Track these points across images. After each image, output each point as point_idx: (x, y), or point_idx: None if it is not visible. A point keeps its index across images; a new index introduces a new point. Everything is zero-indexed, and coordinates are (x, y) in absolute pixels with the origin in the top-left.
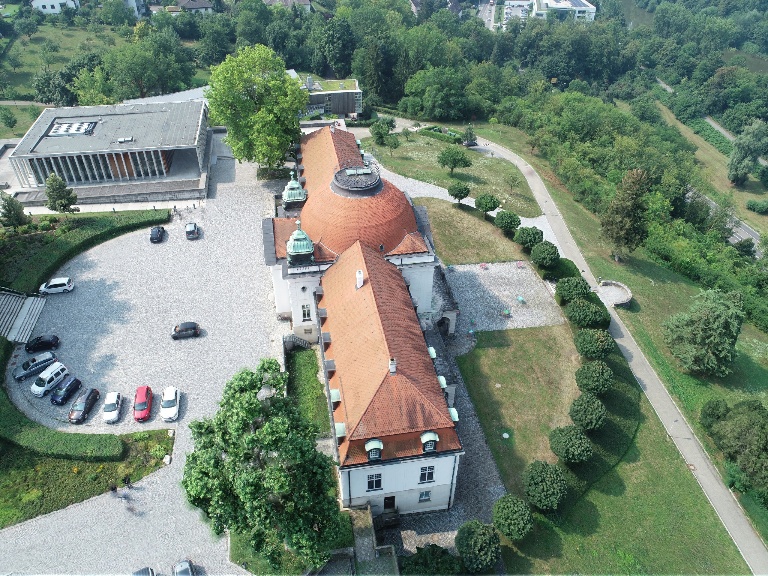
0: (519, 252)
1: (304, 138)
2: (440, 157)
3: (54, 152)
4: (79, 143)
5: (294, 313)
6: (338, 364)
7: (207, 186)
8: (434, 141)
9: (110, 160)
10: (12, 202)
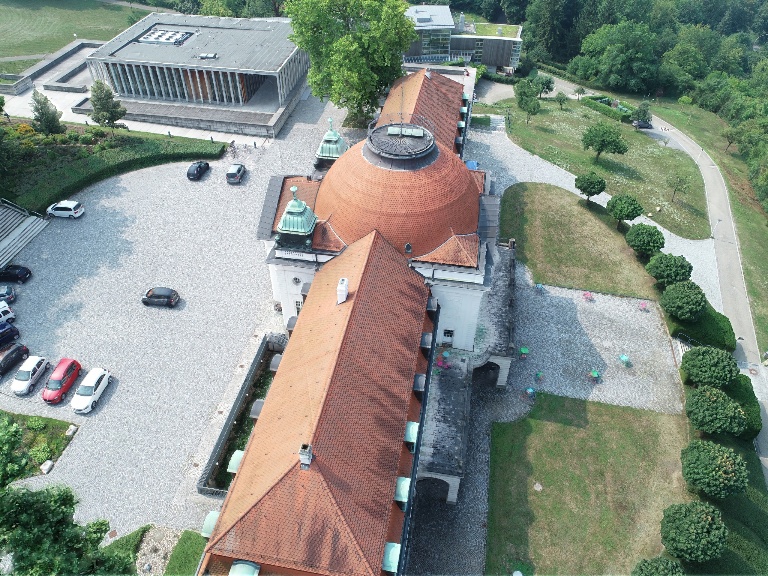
0: (650, 287)
1: (397, 81)
2: (585, 135)
3: (130, 59)
4: (161, 53)
5: (284, 308)
6: (262, 413)
7: (281, 124)
8: (595, 114)
9: (186, 77)
10: (45, 105)
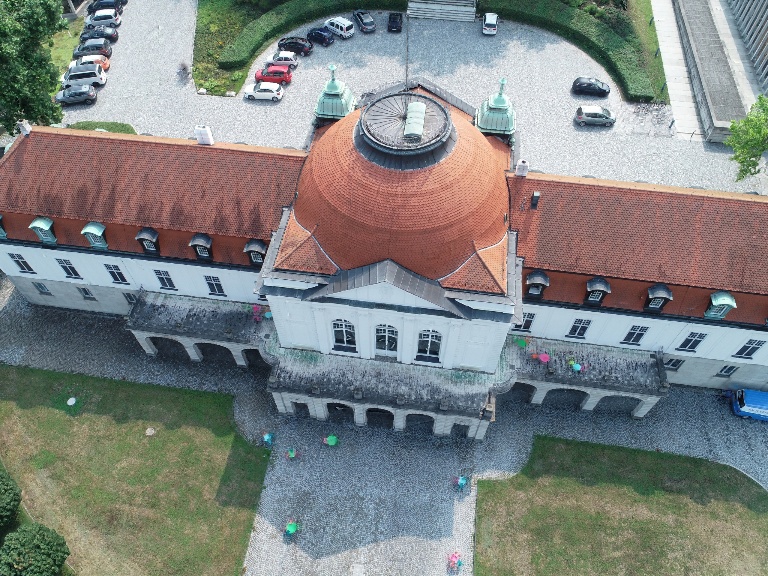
0: None
1: None
2: None
3: None
4: None
5: None
6: None
7: None
8: None
9: None
10: None
